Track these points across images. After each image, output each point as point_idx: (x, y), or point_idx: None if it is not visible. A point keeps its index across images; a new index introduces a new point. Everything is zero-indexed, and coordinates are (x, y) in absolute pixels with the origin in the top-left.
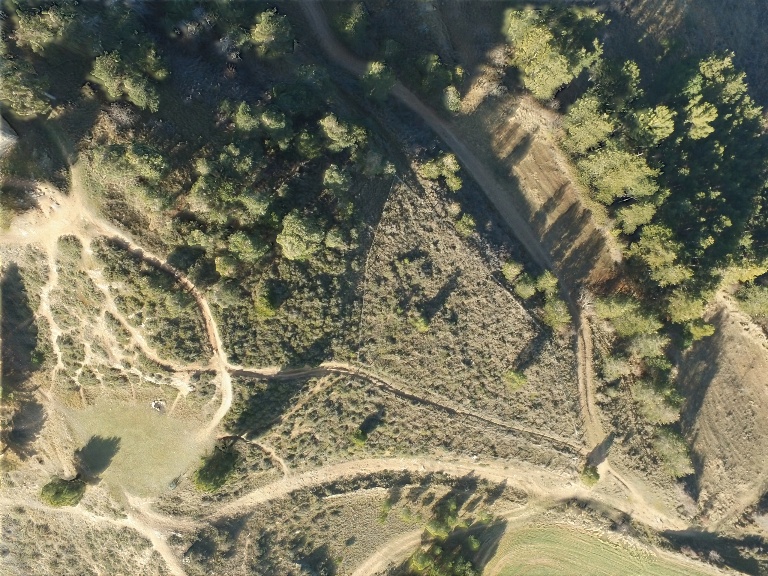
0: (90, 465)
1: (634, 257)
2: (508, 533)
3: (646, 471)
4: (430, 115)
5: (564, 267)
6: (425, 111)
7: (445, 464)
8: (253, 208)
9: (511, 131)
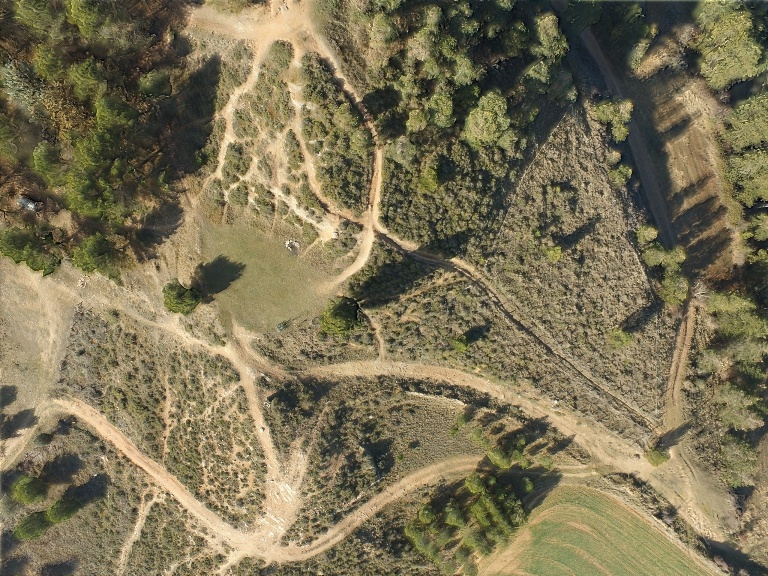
0: (208, 282)
1: (759, 263)
2: (563, 486)
3: (715, 466)
4: (606, 68)
5: (687, 253)
6: (603, 63)
7: (524, 400)
8: (462, 75)
9: (675, 109)
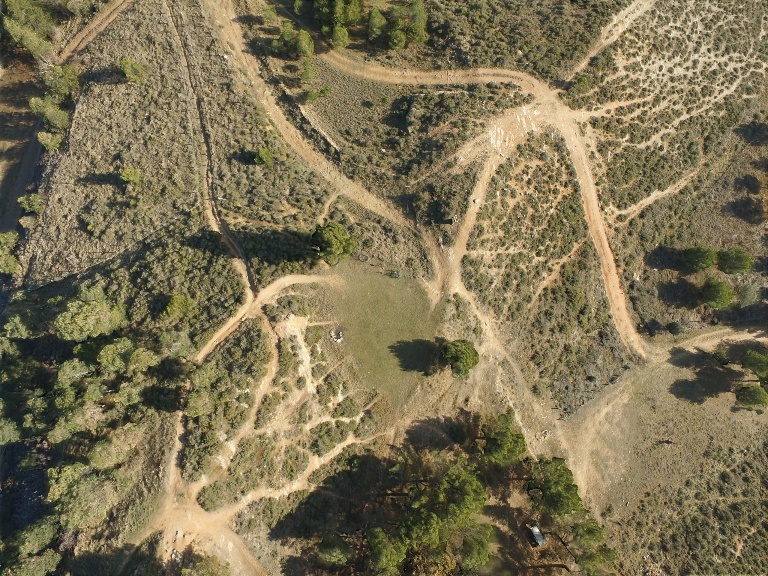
0: (430, 355)
1: None
2: None
3: None
4: None
5: None
6: None
7: (252, 77)
8: (78, 371)
9: None
